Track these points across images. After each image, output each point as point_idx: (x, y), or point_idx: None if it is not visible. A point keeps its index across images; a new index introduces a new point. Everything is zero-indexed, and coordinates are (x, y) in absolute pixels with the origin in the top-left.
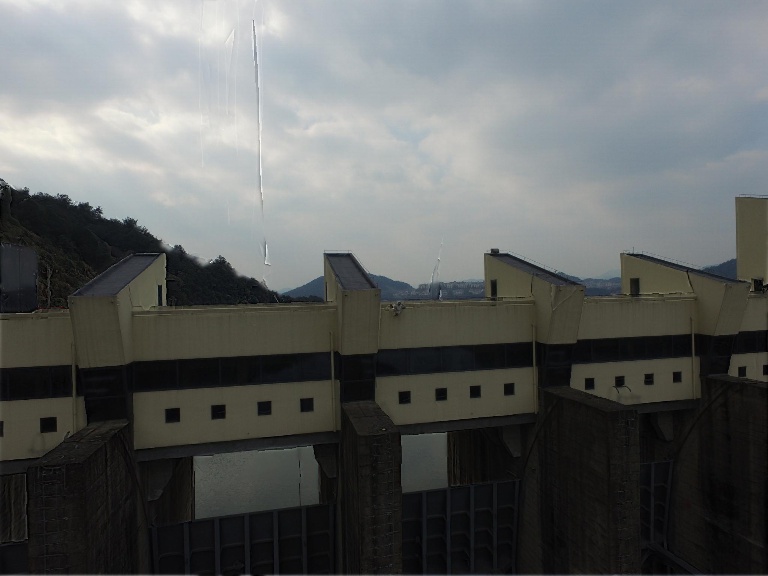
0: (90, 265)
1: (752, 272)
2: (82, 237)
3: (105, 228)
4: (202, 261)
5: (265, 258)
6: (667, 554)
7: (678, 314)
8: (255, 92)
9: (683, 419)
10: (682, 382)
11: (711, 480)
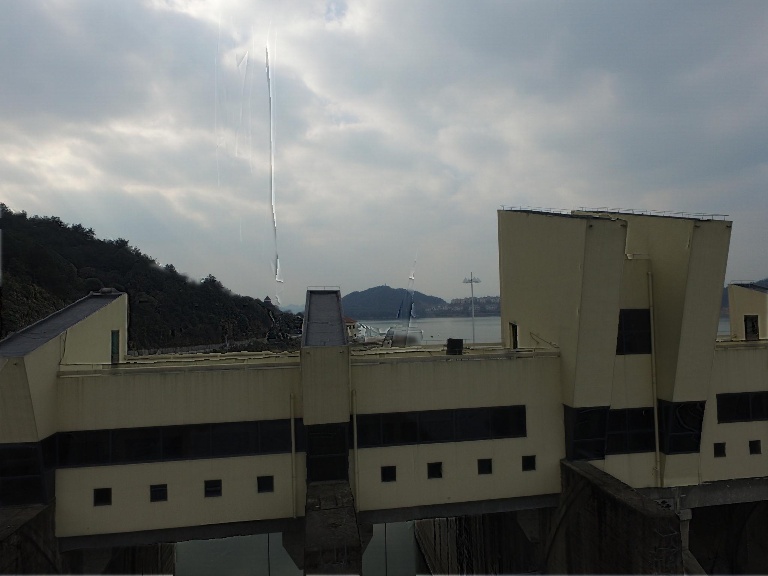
0: (44, 287)
1: (509, 314)
2: (38, 259)
3: (94, 249)
4: (188, 280)
5: (277, 275)
6: None
7: (269, 389)
8: None
9: None
10: (274, 492)
11: None
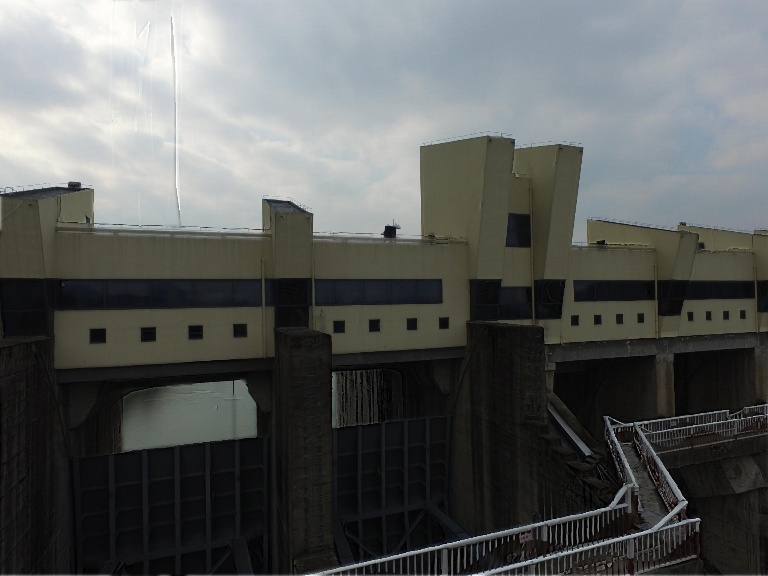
0: None
1: (429, 228)
2: None
3: None
4: None
5: None
6: (239, 551)
7: (244, 254)
8: (172, 89)
9: (272, 385)
10: (248, 337)
11: (277, 456)
